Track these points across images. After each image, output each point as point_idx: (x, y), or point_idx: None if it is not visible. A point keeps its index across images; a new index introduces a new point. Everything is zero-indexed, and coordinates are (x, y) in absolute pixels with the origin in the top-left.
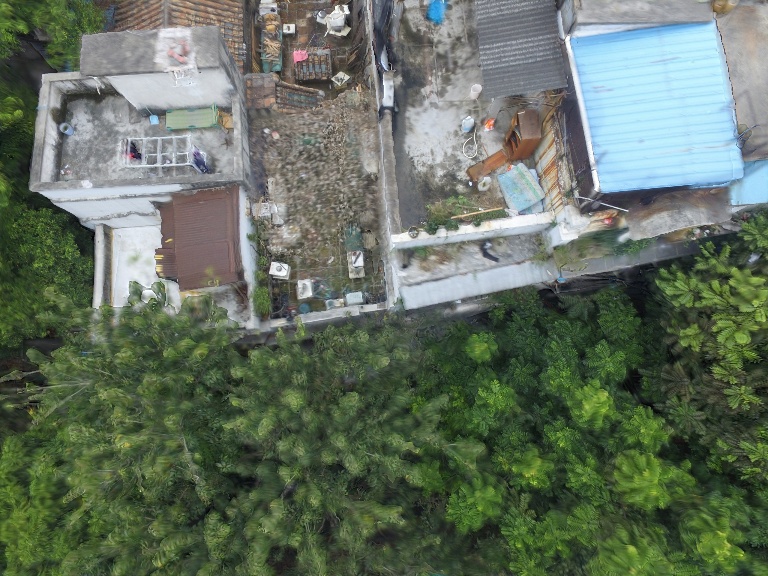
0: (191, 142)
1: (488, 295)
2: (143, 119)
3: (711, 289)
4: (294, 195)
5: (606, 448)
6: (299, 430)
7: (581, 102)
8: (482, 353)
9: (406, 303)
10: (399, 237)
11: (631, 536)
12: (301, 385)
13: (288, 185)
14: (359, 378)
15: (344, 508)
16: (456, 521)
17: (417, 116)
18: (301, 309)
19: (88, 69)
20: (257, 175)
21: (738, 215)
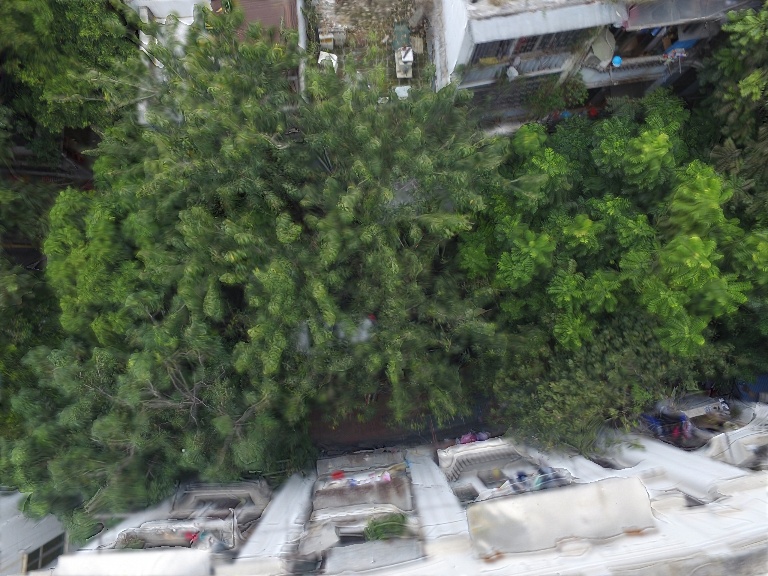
0: None
1: (536, 96)
2: None
3: None
4: None
5: (656, 214)
6: None
7: None
8: (531, 142)
9: (475, 36)
10: None
11: None
12: None
13: None
14: (423, 118)
15: (412, 220)
16: (507, 278)
17: None
18: None
19: None
20: None
21: None
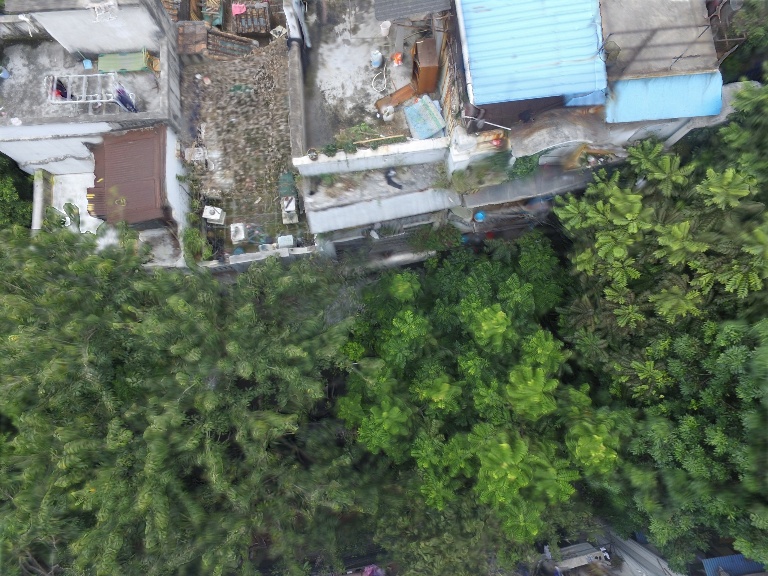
0: (114, 79)
1: (416, 239)
2: (77, 64)
3: (595, 209)
4: (224, 138)
5: None
6: (201, 342)
7: (461, 21)
8: (405, 292)
9: (312, 228)
10: (300, 160)
11: (512, 439)
12: (207, 303)
13: (218, 129)
14: (269, 302)
15: (244, 417)
16: (368, 444)
17: (330, 52)
18: (236, 253)
19: (12, 5)
20: (188, 119)
21: (629, 143)
